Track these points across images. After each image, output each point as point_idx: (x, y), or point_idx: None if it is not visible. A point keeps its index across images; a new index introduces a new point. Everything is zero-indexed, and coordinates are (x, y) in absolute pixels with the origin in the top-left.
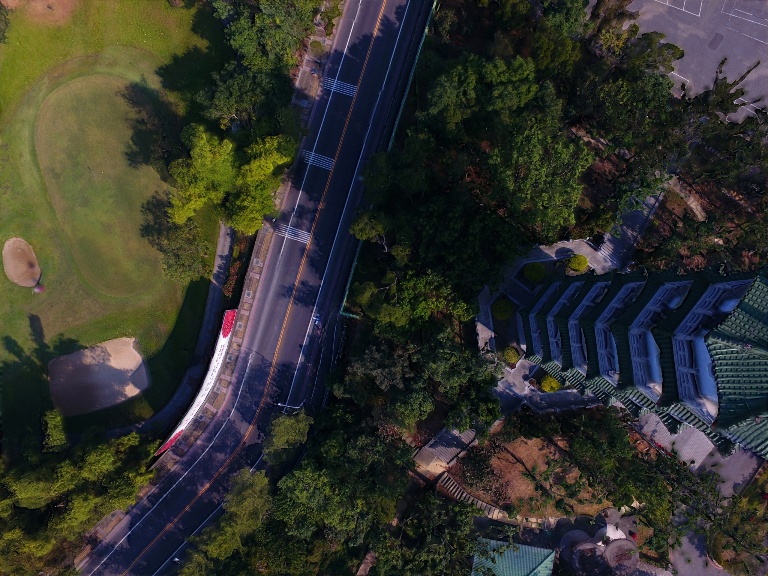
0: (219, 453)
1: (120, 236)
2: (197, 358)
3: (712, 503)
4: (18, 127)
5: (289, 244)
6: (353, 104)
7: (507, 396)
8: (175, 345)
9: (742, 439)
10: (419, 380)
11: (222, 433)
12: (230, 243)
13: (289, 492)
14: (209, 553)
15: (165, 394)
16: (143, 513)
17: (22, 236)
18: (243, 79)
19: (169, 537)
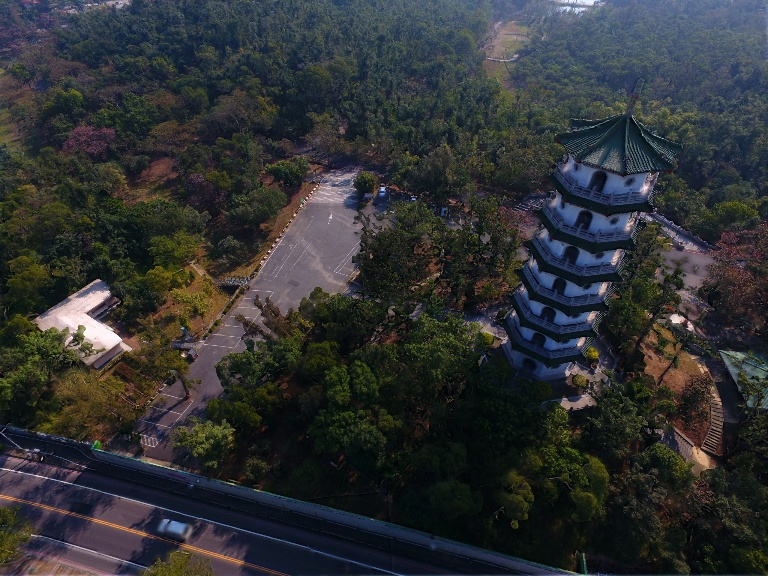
0: None
1: None
2: None
3: None
4: None
5: None
6: None
7: (613, 387)
8: None
9: None
10: (639, 457)
11: None
12: None
13: None
14: None
15: None
16: None
17: None
18: None
19: None
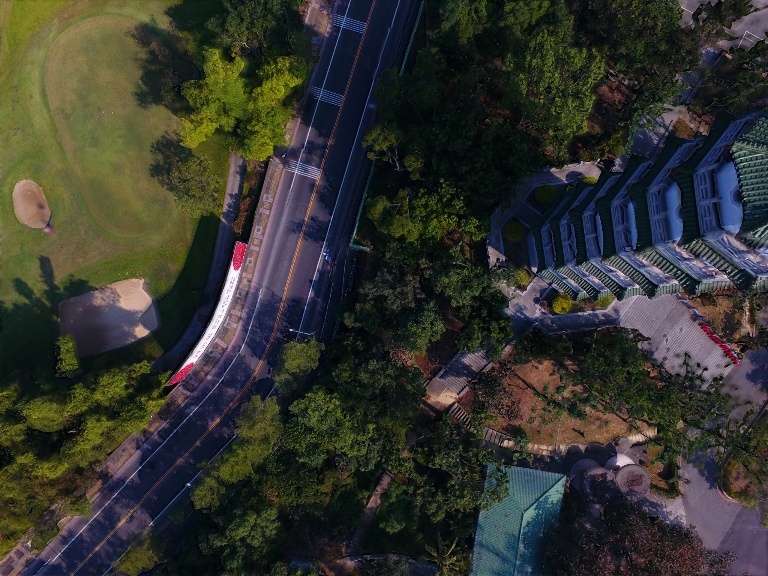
0: (229, 388)
1: (130, 176)
2: (207, 298)
3: None
4: (28, 68)
5: (299, 180)
6: (362, 41)
7: (518, 320)
8: (185, 285)
9: (767, 246)
10: (430, 301)
11: (232, 368)
12: (240, 181)
13: (301, 416)
14: (221, 474)
15: (175, 333)
16: (154, 448)
17: (32, 178)
18: (254, 5)
19: (180, 472)
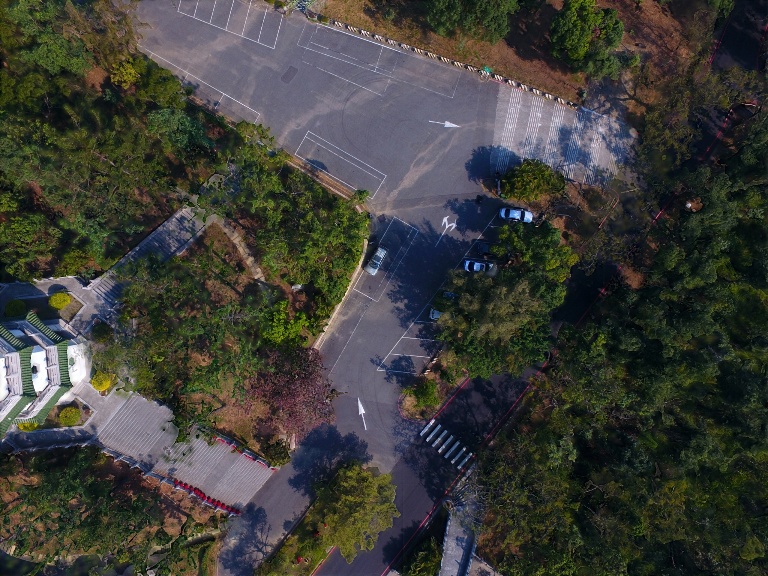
0: None
1: None
2: None
3: (261, 541)
4: None
5: None
6: None
7: None
8: None
9: None
10: None
11: None
12: None
13: None
14: None
15: None
16: None
17: None
18: None
19: None
